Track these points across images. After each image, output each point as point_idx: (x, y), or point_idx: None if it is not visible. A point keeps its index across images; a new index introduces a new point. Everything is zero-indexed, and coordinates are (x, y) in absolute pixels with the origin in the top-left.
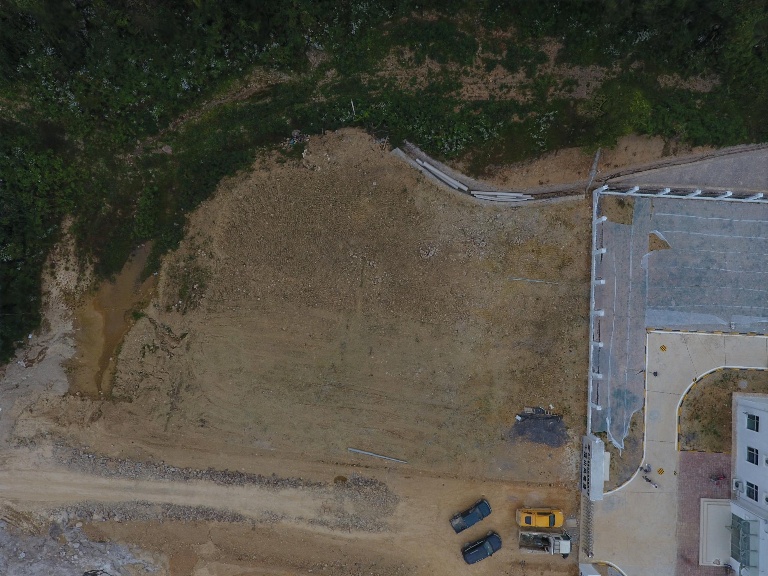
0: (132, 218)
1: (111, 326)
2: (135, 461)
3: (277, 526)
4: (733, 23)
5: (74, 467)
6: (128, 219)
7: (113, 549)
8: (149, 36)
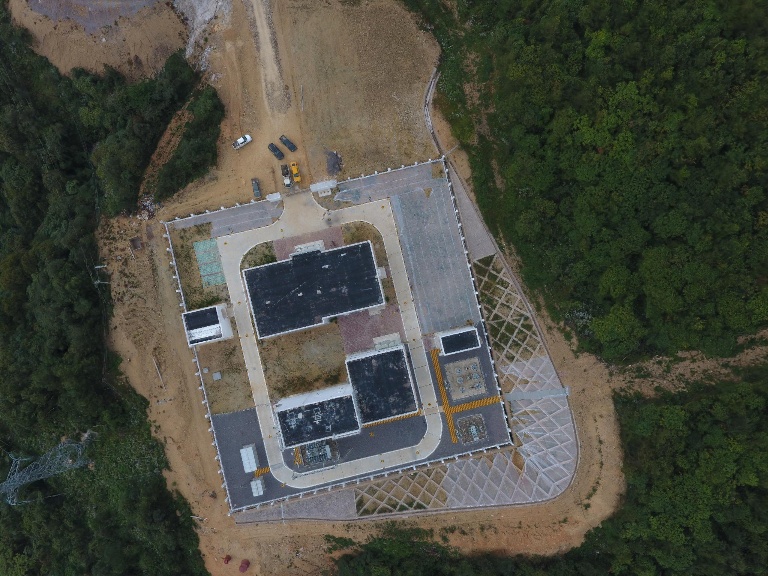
0: None
1: None
2: (269, 0)
3: (260, 67)
4: None
5: None
6: None
7: (228, 4)
8: None
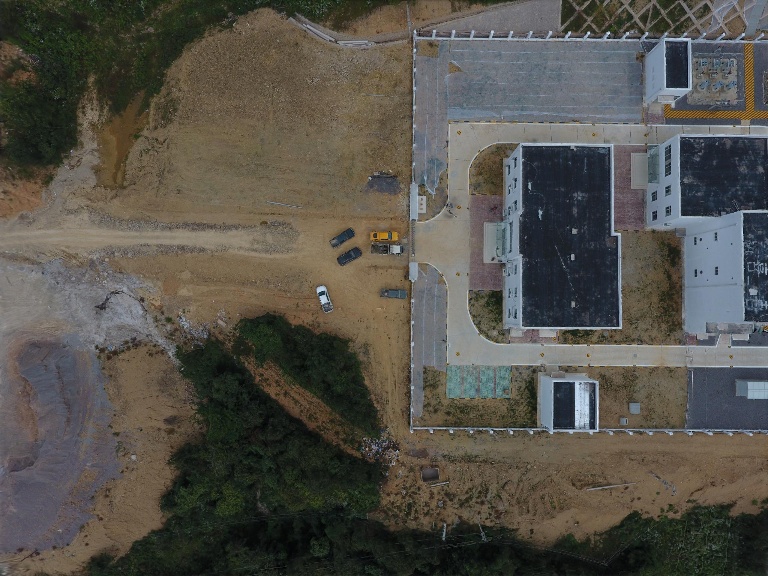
0: (131, 75)
1: (121, 144)
2: (139, 220)
3: (226, 253)
4: None
5: (102, 225)
6: (129, 76)
7: (128, 278)
8: None
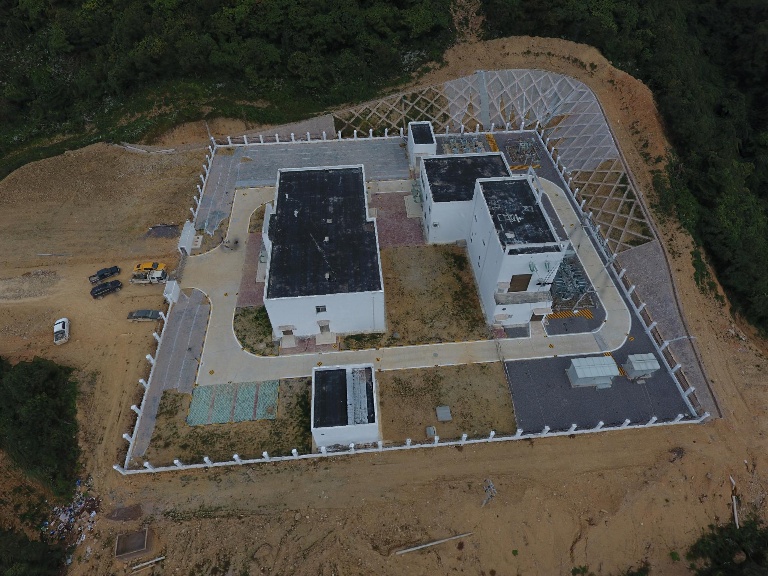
0: None
1: None
2: None
3: None
4: (244, 70)
5: None
6: None
7: None
8: (6, 127)
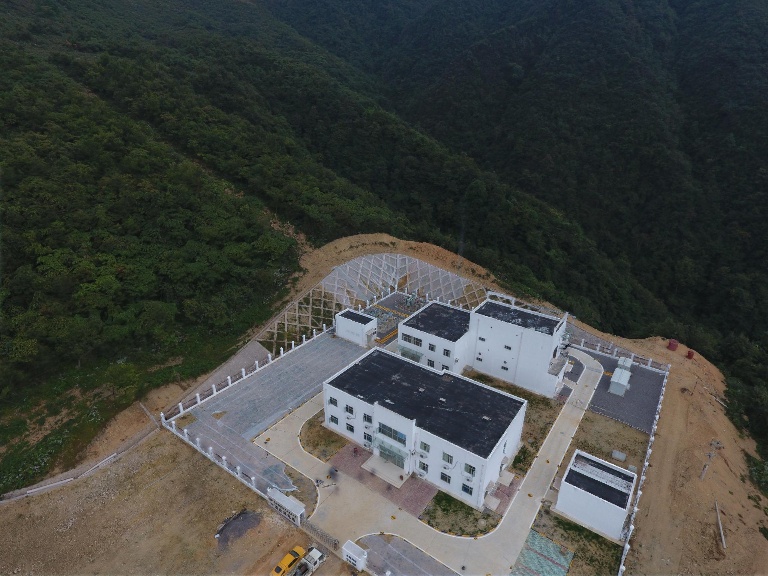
0: None
1: None
2: None
3: None
4: (152, 333)
5: None
6: None
7: None
8: None
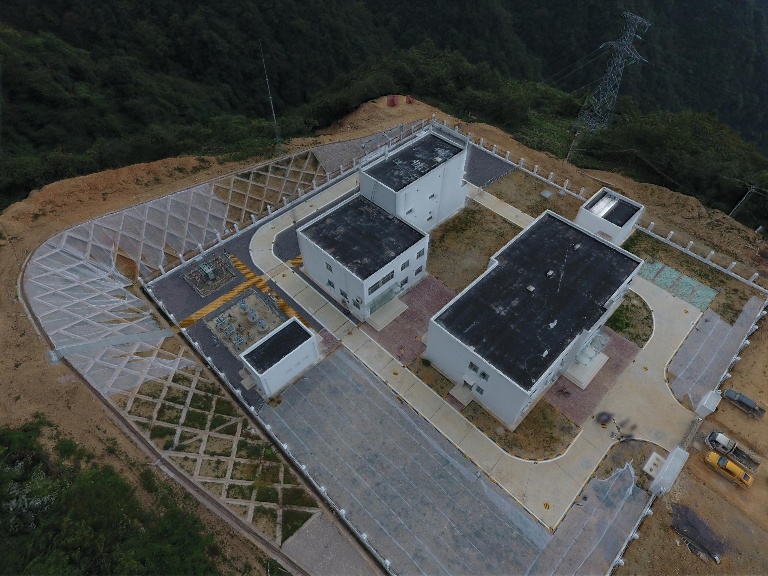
0: None
1: None
2: None
3: None
4: None
5: None
6: None
7: None
8: None
